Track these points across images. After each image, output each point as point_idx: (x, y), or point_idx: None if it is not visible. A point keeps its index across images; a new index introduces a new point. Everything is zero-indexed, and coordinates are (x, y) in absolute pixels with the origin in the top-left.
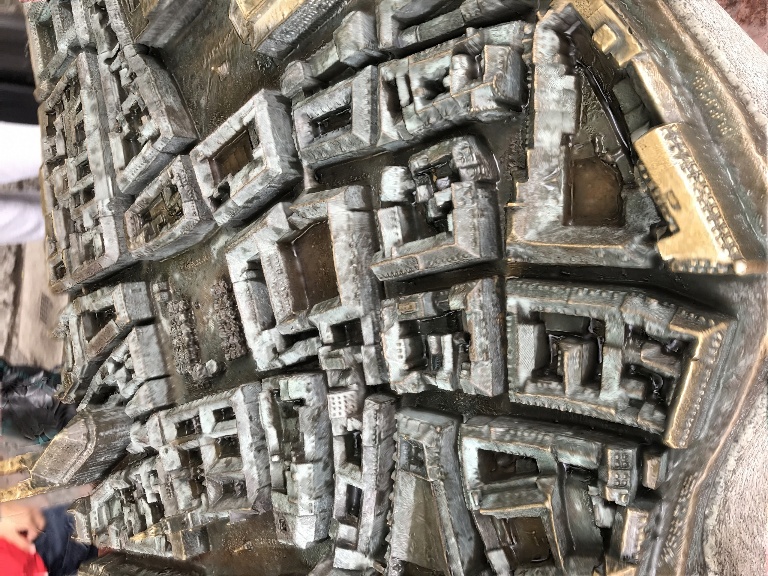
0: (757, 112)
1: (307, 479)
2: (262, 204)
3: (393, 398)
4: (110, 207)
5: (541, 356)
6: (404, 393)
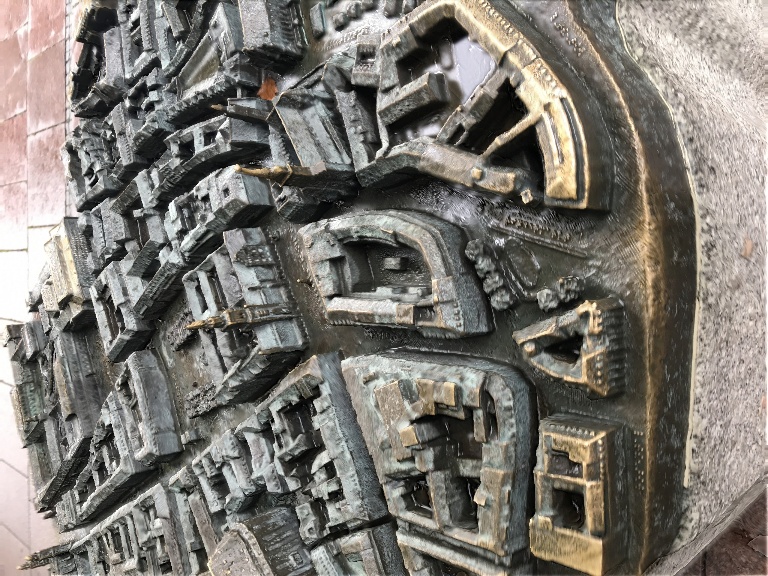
0: None
1: None
2: None
3: None
4: None
5: None
6: None
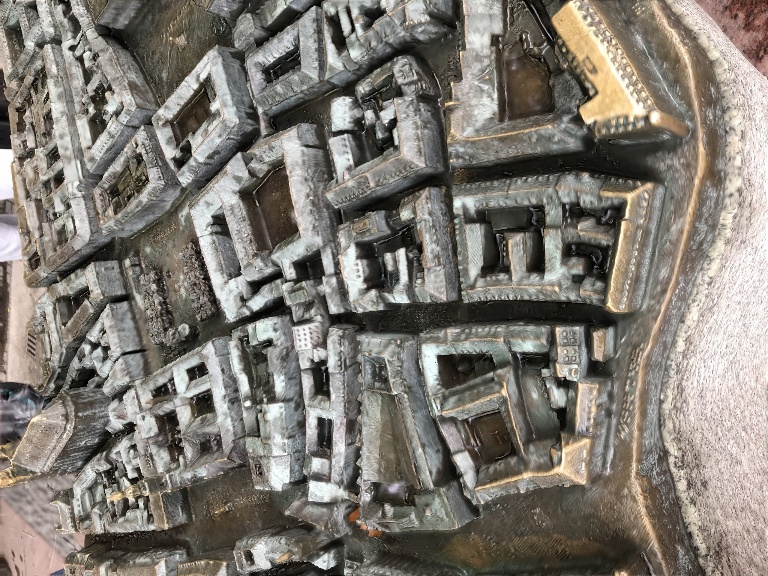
0: (673, 3)
1: (279, 418)
2: (224, 160)
3: (357, 326)
4: (80, 189)
5: (490, 255)
6: (368, 321)
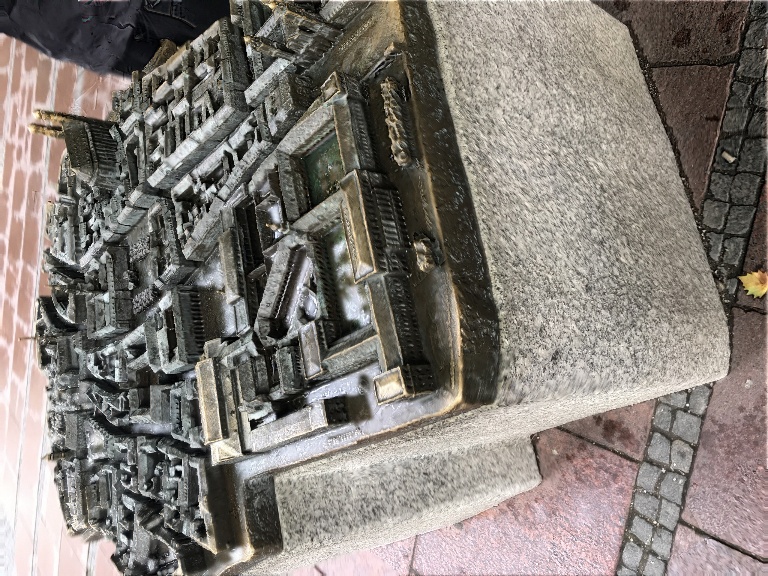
0: None
1: None
2: None
3: None
4: (168, 172)
5: None
6: None
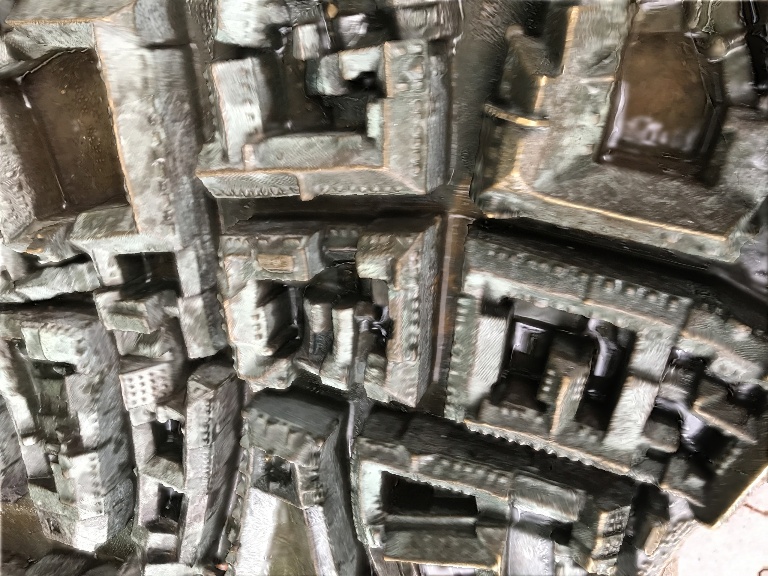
0: None
1: (89, 474)
2: None
3: (233, 370)
4: None
5: None
6: None
